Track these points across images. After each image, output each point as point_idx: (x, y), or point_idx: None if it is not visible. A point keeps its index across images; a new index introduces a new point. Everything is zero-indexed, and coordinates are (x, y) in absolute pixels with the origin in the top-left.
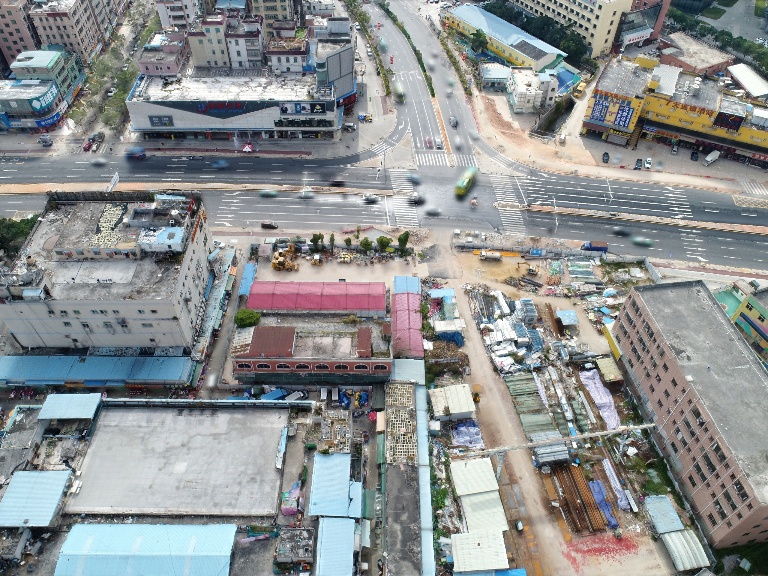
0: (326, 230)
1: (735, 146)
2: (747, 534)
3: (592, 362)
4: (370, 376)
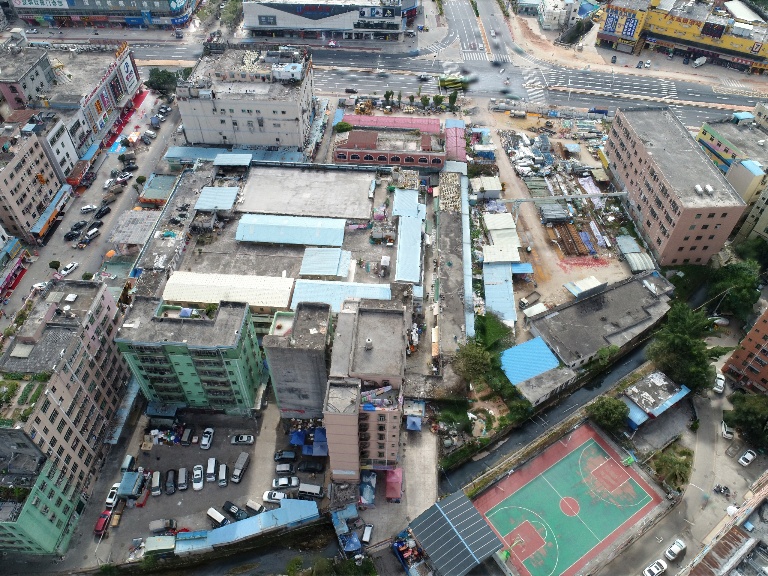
0: (394, 95)
1: (719, 52)
2: (682, 249)
3: (588, 172)
4: (429, 168)
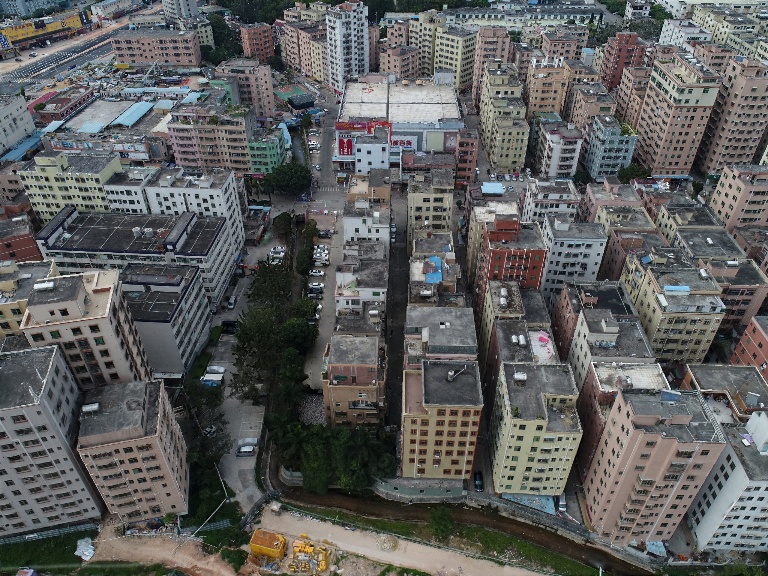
0: None
1: (50, 35)
2: None
3: None
4: None
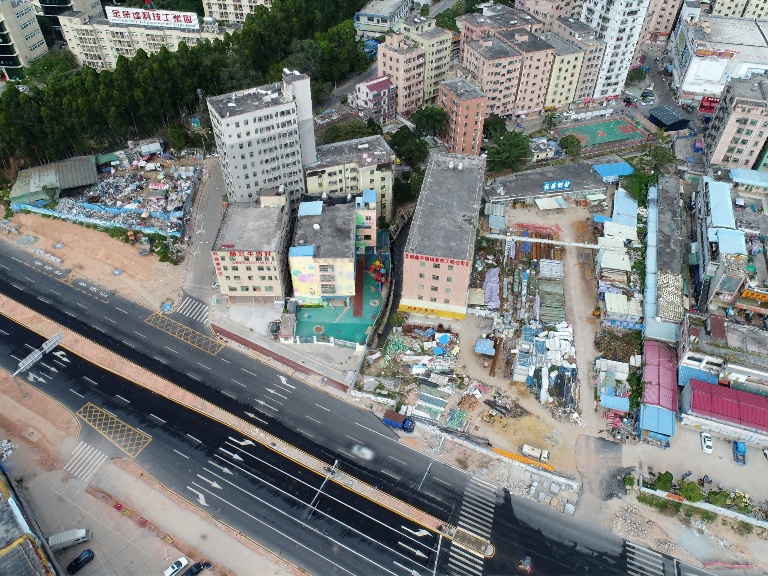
0: None
1: None
2: None
3: None
4: None
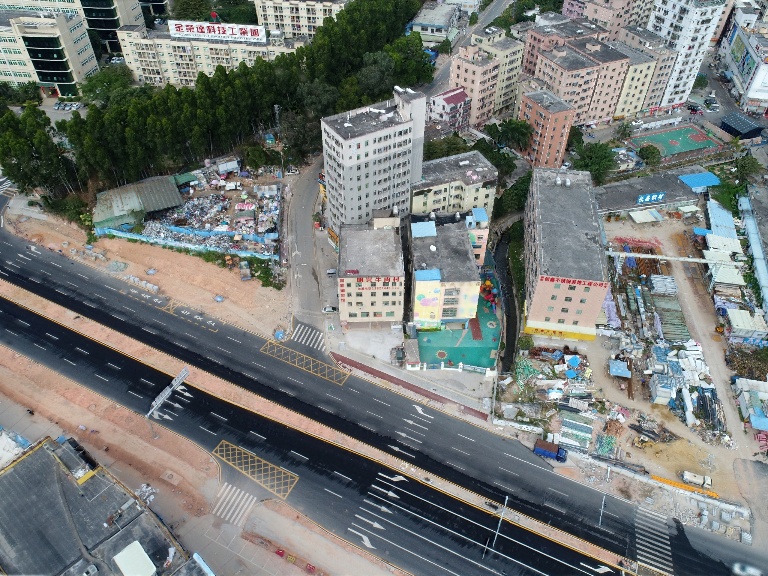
0: None
1: None
2: None
3: None
4: None
